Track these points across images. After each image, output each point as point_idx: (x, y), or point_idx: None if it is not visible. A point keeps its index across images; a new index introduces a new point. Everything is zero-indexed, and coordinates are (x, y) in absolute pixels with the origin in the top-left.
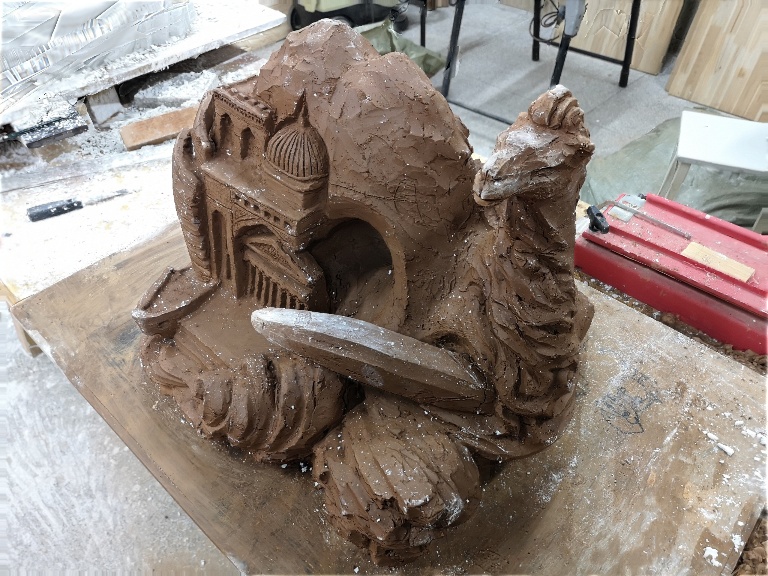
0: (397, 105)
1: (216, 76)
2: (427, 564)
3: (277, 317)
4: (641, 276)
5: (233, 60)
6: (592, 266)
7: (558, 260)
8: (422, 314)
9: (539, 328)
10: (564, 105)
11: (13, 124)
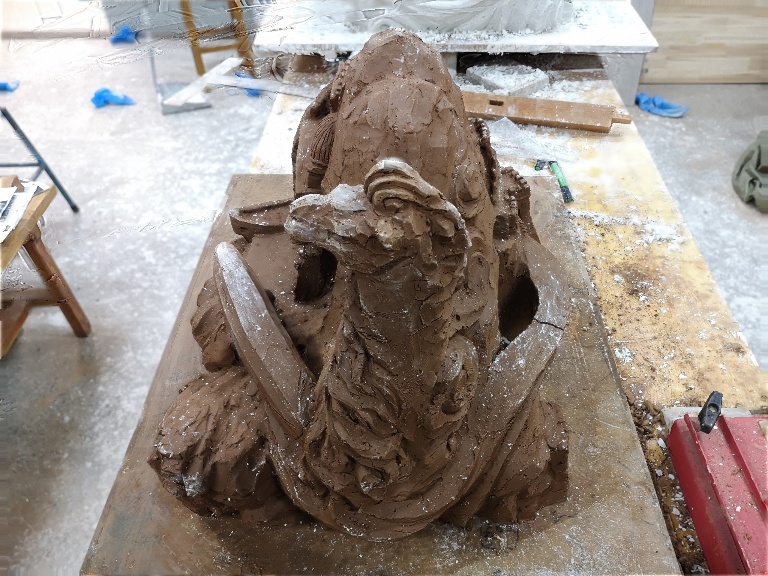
0: (380, 128)
1: (547, 78)
2: (217, 531)
3: (223, 254)
4: (707, 511)
5: (583, 71)
6: (679, 460)
7: (369, 346)
8: (330, 333)
9: (339, 402)
10: (379, 180)
11: (353, 53)
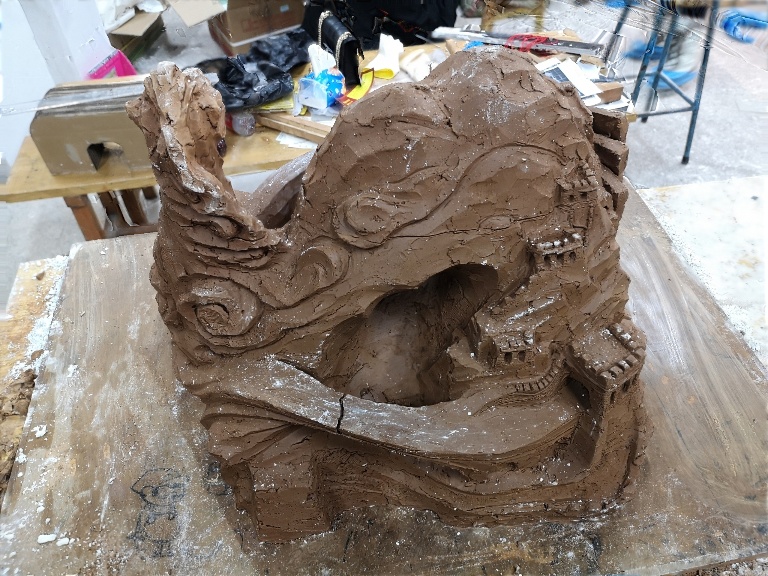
0: None
1: None
2: None
3: None
4: None
5: None
6: None
7: None
8: None
9: None
10: None
11: None
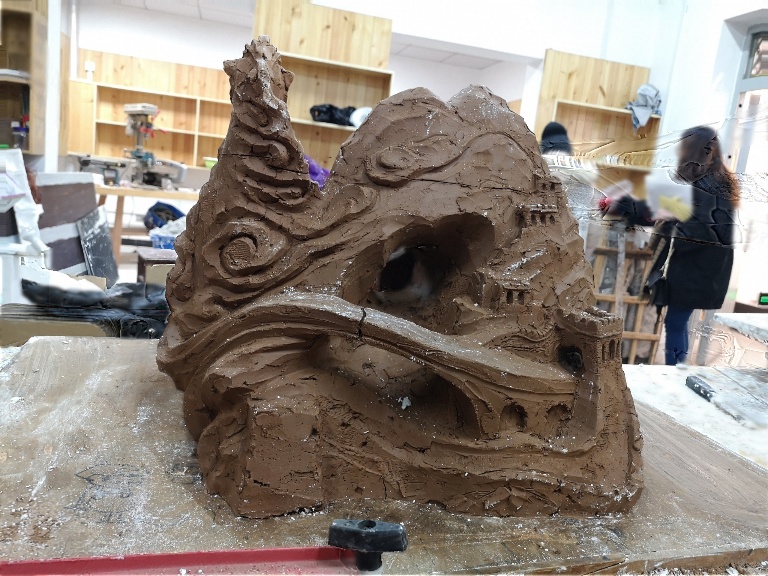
0: None
1: None
2: None
3: None
4: None
5: None
6: None
7: None
8: None
9: None
10: None
11: None
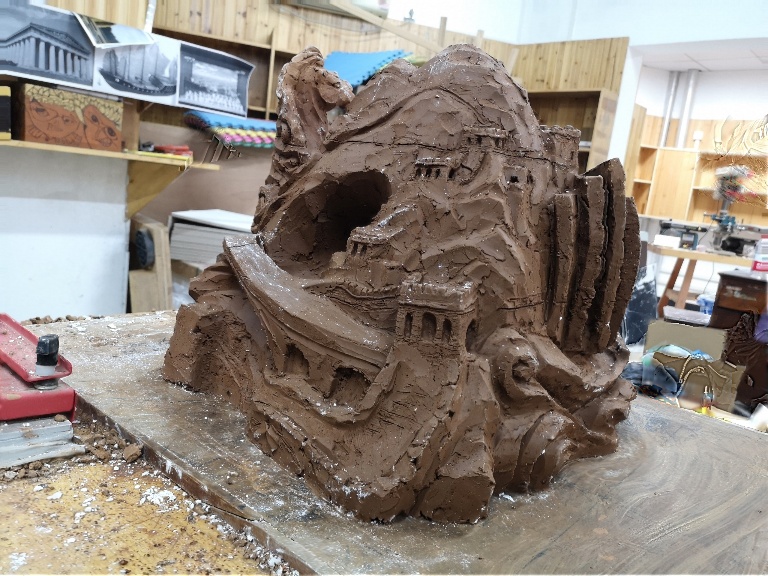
0: None
1: None
2: None
3: None
4: None
5: None
6: None
7: None
8: None
9: None
10: None
11: None
